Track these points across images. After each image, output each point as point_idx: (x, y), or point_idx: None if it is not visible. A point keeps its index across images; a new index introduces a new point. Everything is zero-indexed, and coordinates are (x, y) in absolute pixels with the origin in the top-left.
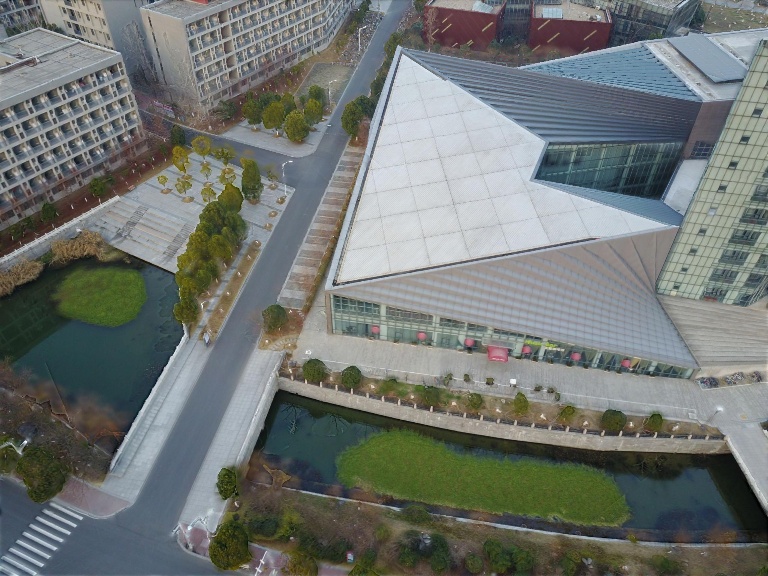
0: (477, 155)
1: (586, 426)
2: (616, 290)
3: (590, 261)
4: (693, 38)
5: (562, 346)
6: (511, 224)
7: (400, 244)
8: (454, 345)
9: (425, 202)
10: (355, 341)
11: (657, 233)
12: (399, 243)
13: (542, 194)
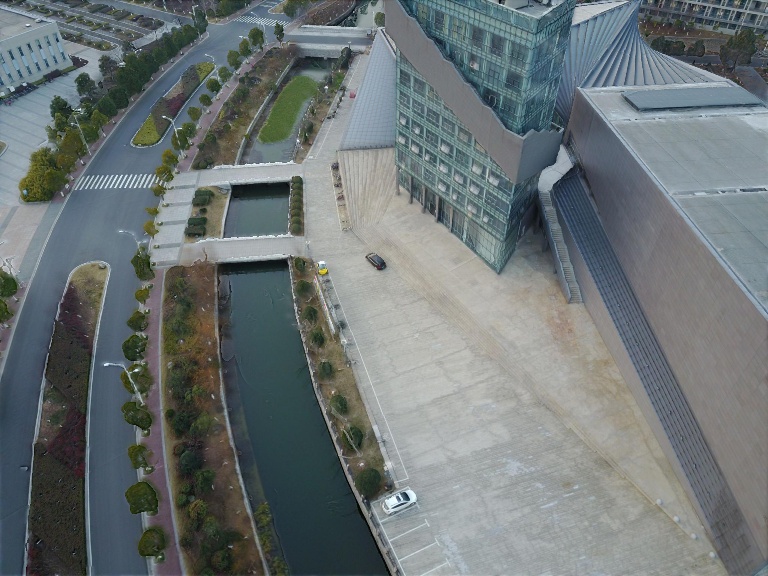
0: None
1: None
2: None
3: None
4: (746, 96)
5: None
6: None
7: None
8: None
9: None
10: None
11: None
12: None
13: None
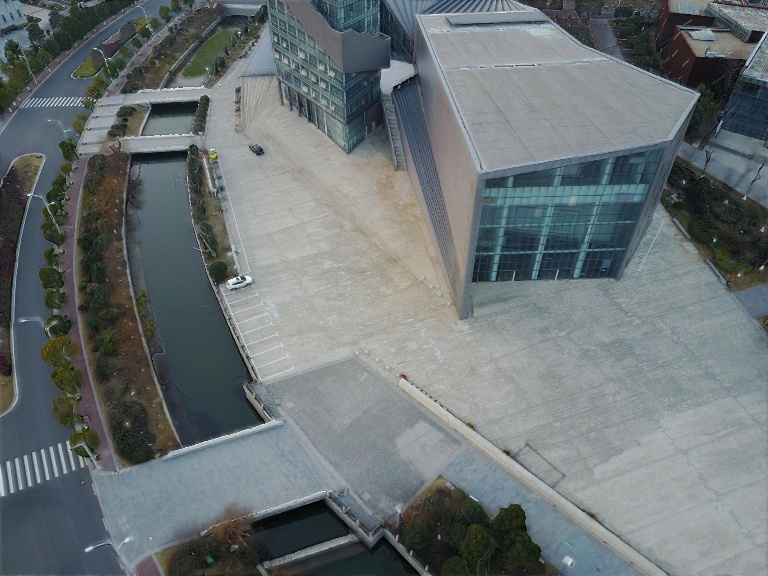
0: None
1: None
2: None
3: None
4: (539, 17)
5: None
6: None
7: None
8: None
9: None
10: None
11: None
12: None
13: None
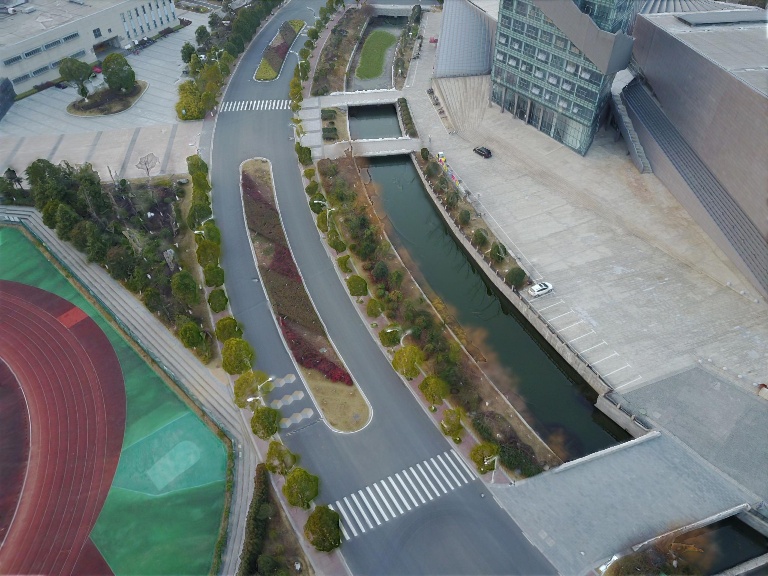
0: None
1: None
2: None
3: None
4: None
5: None
6: None
7: None
8: None
9: None
10: None
11: None
12: None
13: None
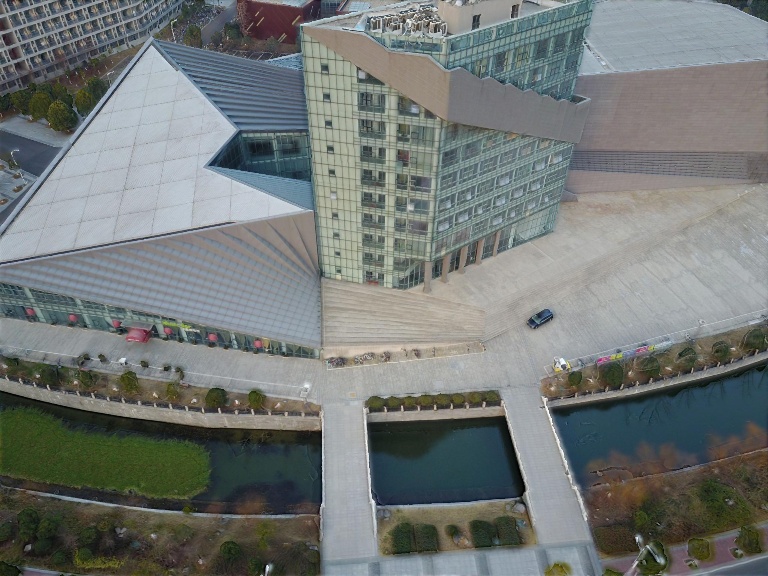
0: (169, 143)
1: (193, 404)
2: (263, 273)
3: (232, 245)
4: None
5: (196, 327)
6: (165, 209)
7: (56, 228)
8: (106, 327)
9: (99, 188)
10: (15, 323)
11: (293, 217)
12: (56, 227)
13: (207, 180)
